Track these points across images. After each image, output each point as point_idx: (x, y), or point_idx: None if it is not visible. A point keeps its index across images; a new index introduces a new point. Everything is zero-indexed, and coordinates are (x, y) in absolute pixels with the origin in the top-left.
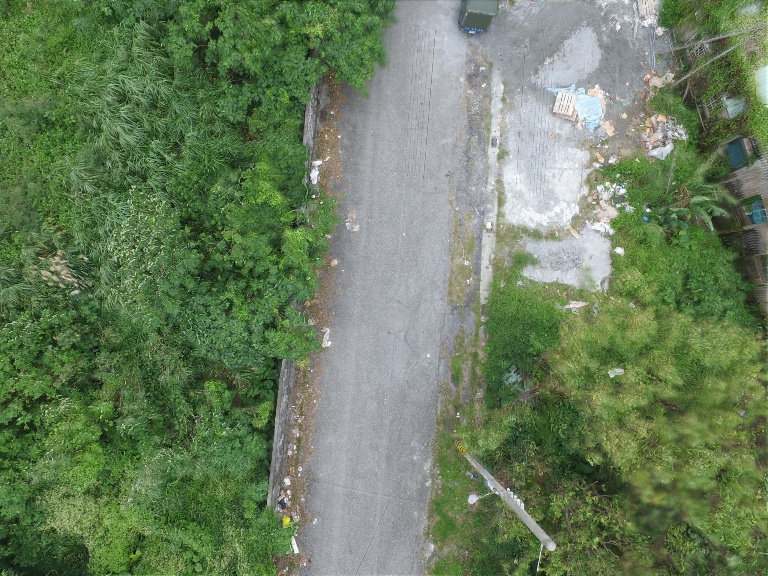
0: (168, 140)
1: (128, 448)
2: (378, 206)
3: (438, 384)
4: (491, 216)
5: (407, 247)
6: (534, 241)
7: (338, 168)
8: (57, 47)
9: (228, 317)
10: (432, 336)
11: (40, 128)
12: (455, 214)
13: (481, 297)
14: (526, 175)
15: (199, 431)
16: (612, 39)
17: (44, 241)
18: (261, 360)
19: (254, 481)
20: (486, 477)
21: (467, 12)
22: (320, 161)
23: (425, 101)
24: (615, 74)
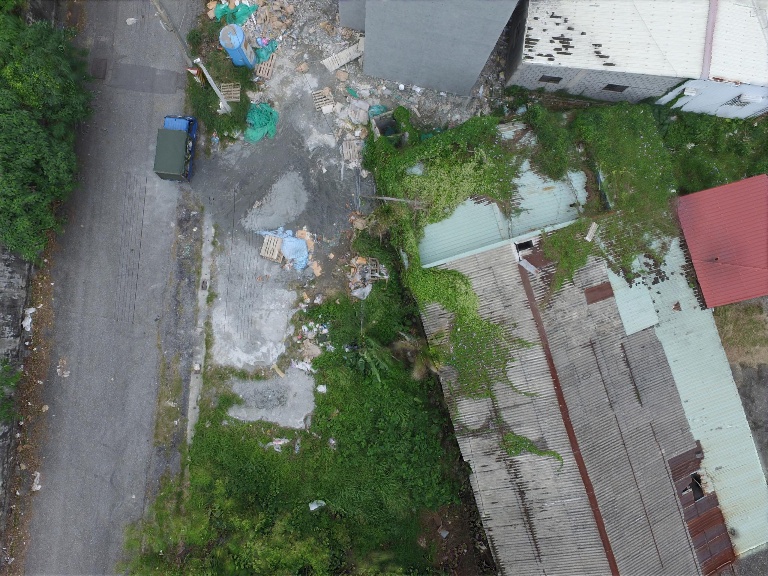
0: None
1: None
2: (88, 352)
3: (143, 523)
4: (200, 358)
5: (115, 391)
6: (241, 381)
7: (50, 315)
8: None
9: None
10: (138, 477)
11: None
12: (163, 357)
13: (188, 437)
14: (234, 317)
15: None
16: (320, 181)
17: None
18: None
19: None
20: None
21: None
22: (34, 308)
23: (135, 247)
24: (322, 215)
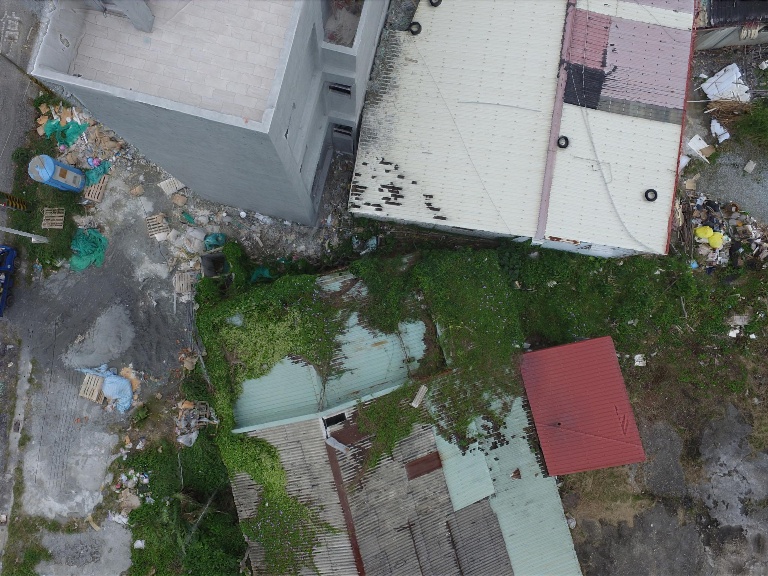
0: None
1: None
2: None
3: None
4: (7, 508)
5: None
6: (51, 534)
7: None
8: None
9: None
10: None
11: None
12: None
13: None
14: (47, 463)
15: None
16: (151, 314)
17: None
18: None
19: None
20: None
21: None
22: None
23: None
24: (151, 352)
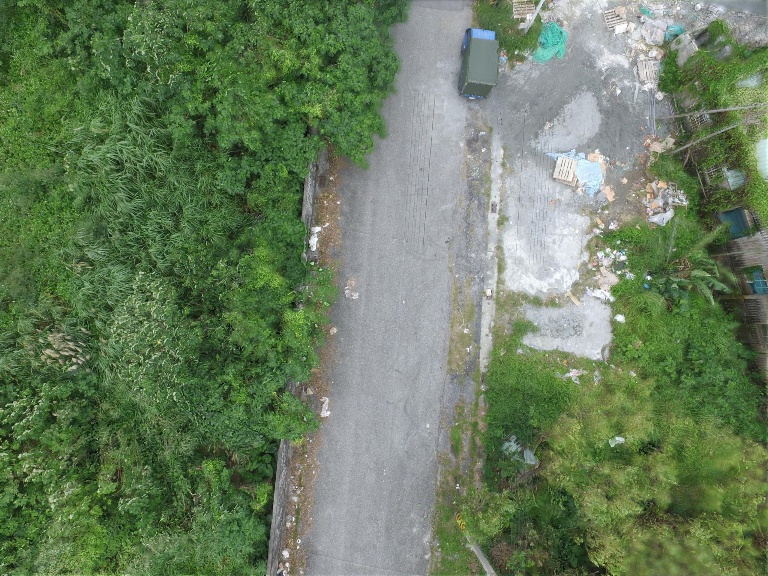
0: (166, 211)
1: (126, 523)
2: (377, 273)
3: (438, 455)
4: (491, 283)
5: (406, 315)
6: (534, 308)
7: (337, 235)
8: (55, 116)
9: (226, 401)
10: (432, 406)
11: (38, 196)
12: (455, 281)
13: (481, 365)
14: (526, 241)
15: (197, 511)
16: (612, 103)
17: (42, 312)
18: (259, 438)
19: (252, 557)
20: (486, 569)
21: (467, 82)
22: (319, 227)
23: (425, 167)
24: (615, 138)
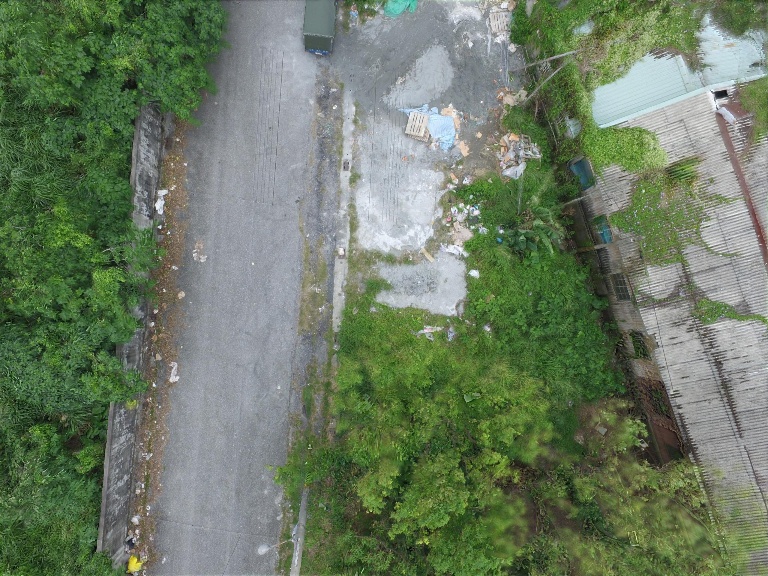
0: None
1: None
2: (226, 235)
3: (289, 416)
4: (343, 242)
5: (256, 276)
6: (388, 266)
7: (185, 197)
8: None
9: (40, 363)
10: (283, 367)
11: None
12: (306, 241)
13: (334, 325)
14: (379, 199)
15: (24, 478)
16: (466, 56)
17: None
18: (90, 402)
19: (93, 524)
20: None
21: (303, 35)
22: (166, 190)
23: (273, 125)
24: (469, 92)
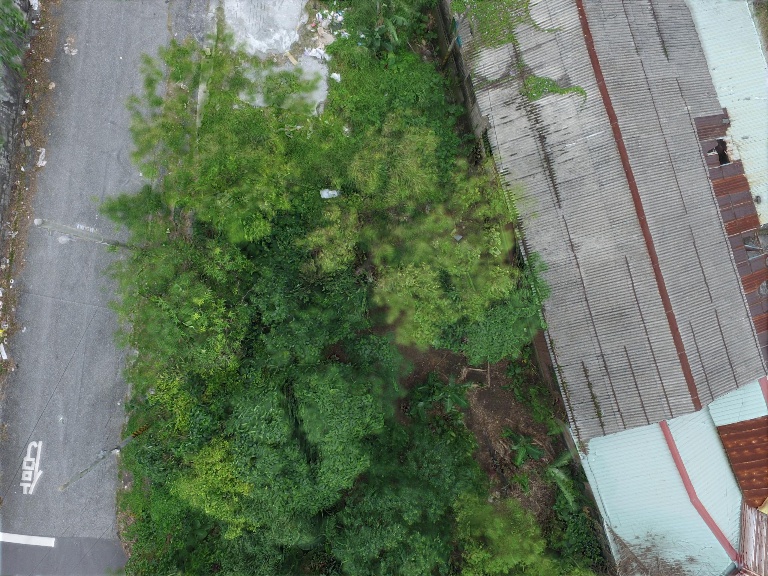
0: None
1: None
2: (96, 30)
3: (150, 201)
4: (211, 43)
5: (124, 70)
6: (252, 67)
7: None
8: None
9: None
10: (145, 156)
11: None
12: (173, 39)
13: (198, 120)
14: (247, 3)
15: None
16: None
17: None
18: None
19: None
20: None
21: None
22: None
23: None
24: None
